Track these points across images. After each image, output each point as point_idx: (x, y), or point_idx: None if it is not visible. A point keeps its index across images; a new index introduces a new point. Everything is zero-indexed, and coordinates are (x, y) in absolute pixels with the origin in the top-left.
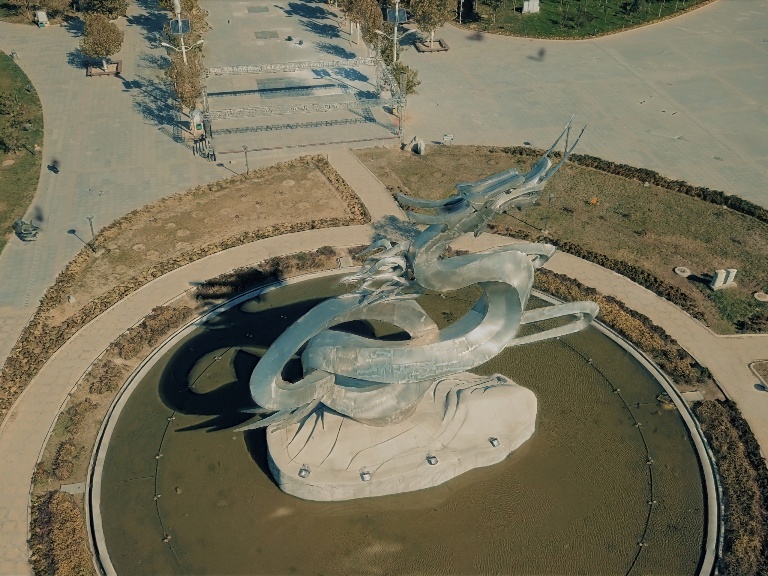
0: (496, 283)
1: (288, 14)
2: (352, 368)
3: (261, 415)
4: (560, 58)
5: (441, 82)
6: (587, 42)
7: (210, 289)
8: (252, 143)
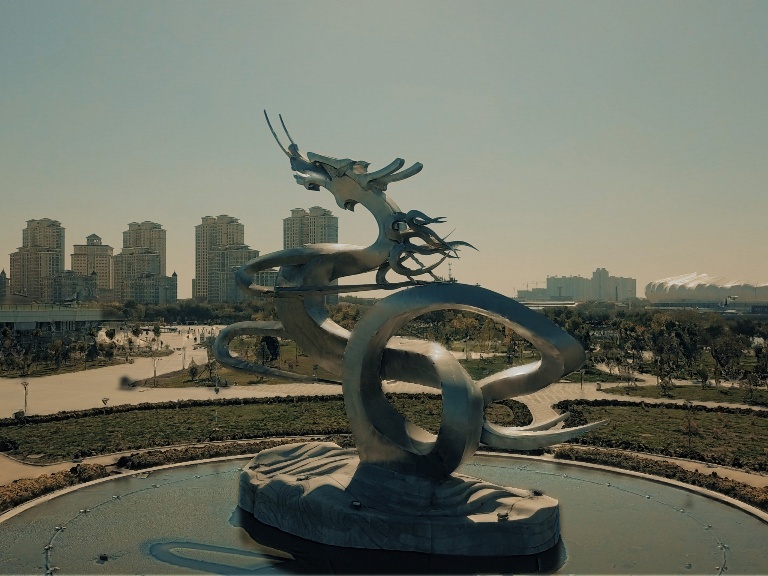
0: None
1: None
2: None
3: None
4: None
5: None
6: None
7: None
8: None
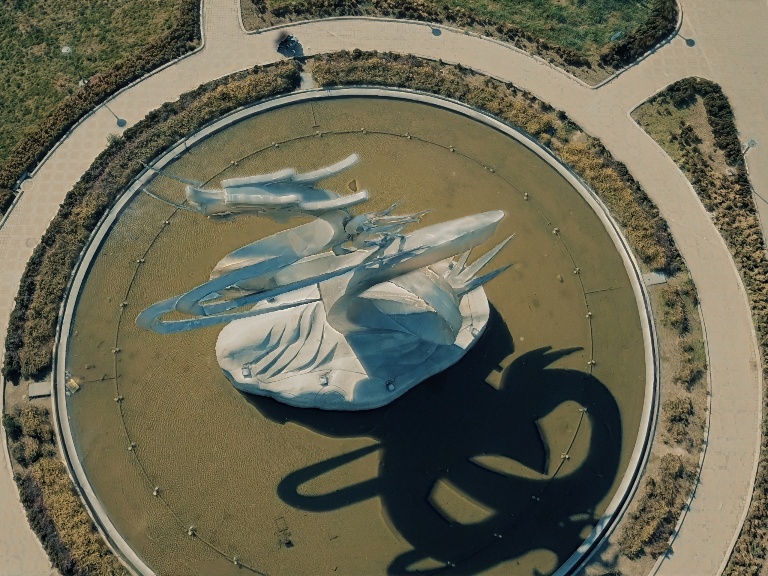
0: None
1: None
2: None
3: (501, 369)
4: None
5: None
6: None
7: None
8: None
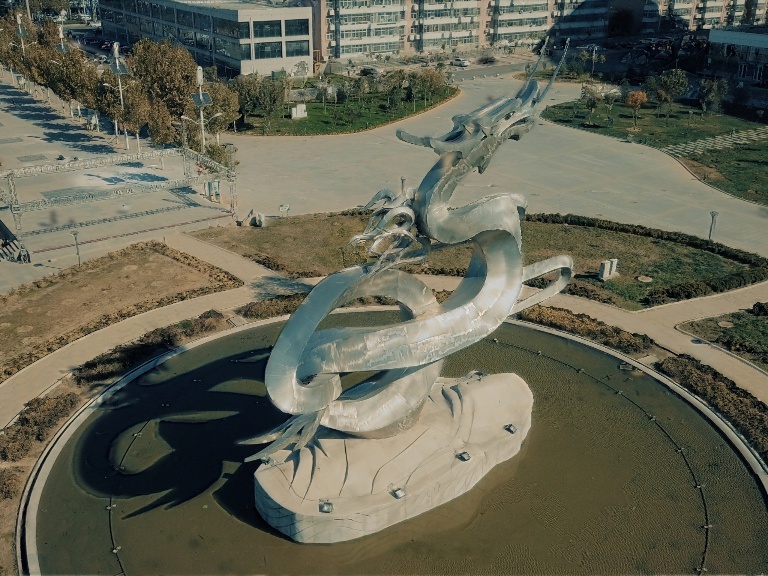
0: (495, 234)
1: (47, 141)
2: (362, 360)
3: (225, 476)
4: (347, 146)
5: (245, 173)
6: (364, 134)
7: (92, 370)
8: (70, 238)
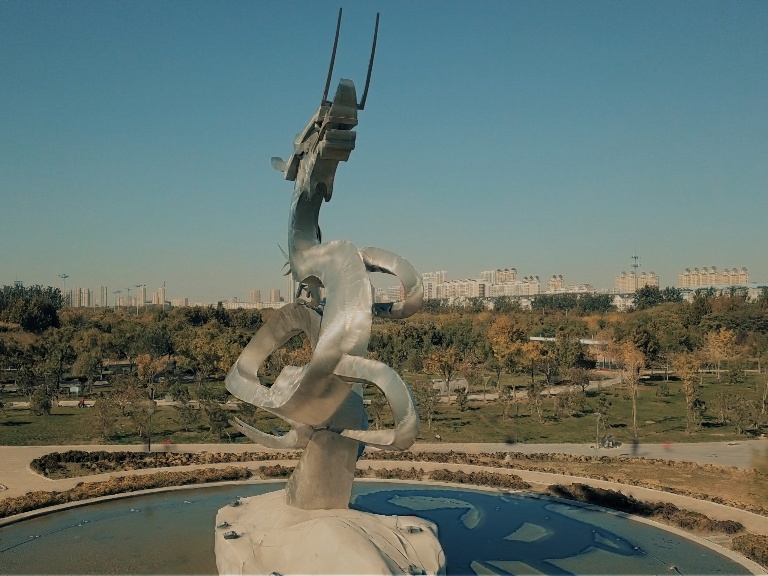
0: None
1: None
2: None
3: None
4: None
5: None
6: None
7: None
8: None
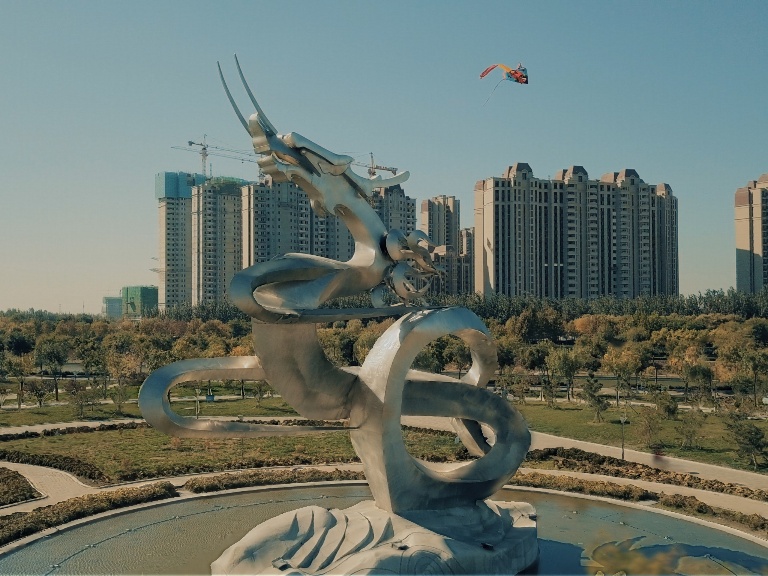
0: None
1: None
2: None
3: None
4: None
5: None
6: None
7: None
8: None
